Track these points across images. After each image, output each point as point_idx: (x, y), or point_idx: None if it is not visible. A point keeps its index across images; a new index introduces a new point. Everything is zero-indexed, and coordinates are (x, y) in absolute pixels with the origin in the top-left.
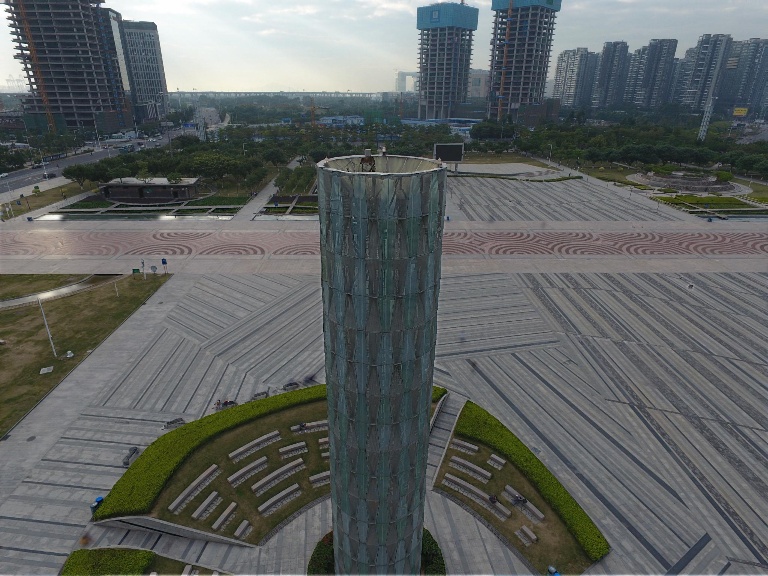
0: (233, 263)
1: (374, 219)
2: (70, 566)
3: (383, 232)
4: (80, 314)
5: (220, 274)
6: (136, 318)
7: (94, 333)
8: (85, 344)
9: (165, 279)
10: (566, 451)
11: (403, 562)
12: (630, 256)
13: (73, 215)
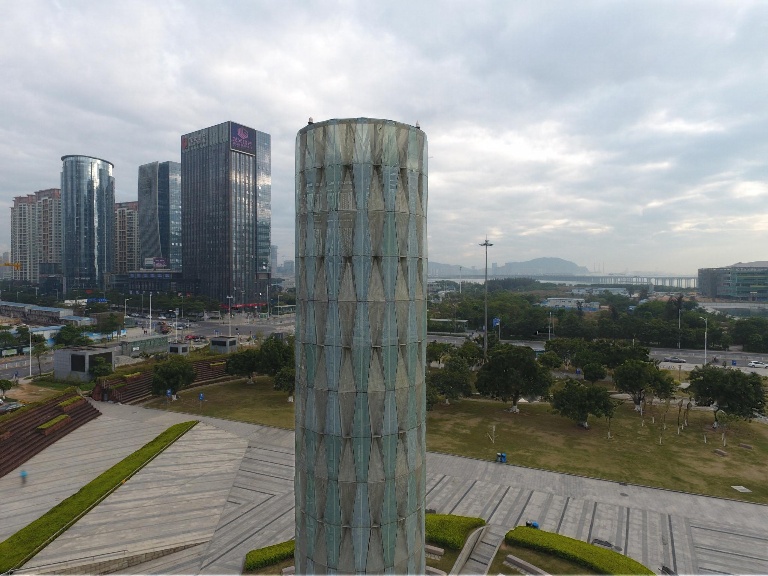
0: None
1: None
2: None
3: None
4: None
5: None
6: None
7: None
8: None
9: None
10: None
11: None
12: None
13: None
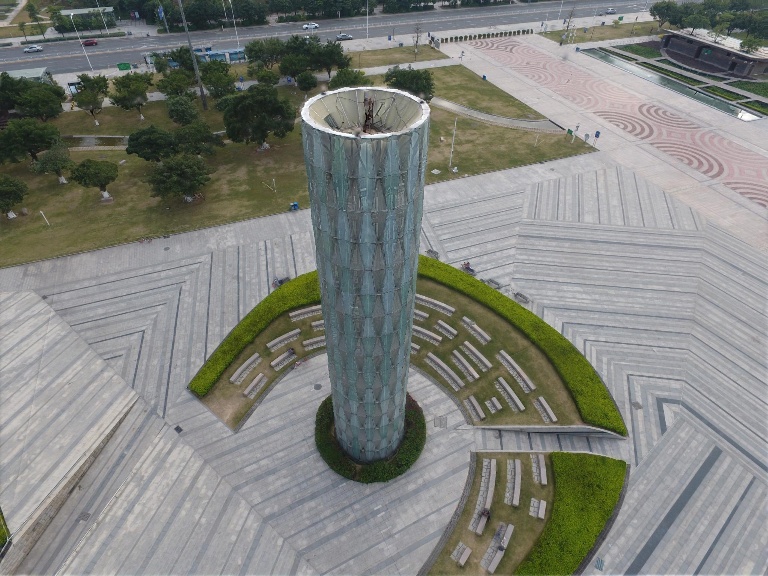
0: (664, 170)
1: None
2: (315, 271)
3: None
4: (498, 146)
5: (635, 173)
6: (521, 170)
7: (485, 165)
8: (471, 169)
9: (585, 151)
10: None
11: (345, 423)
12: None
13: (612, 57)
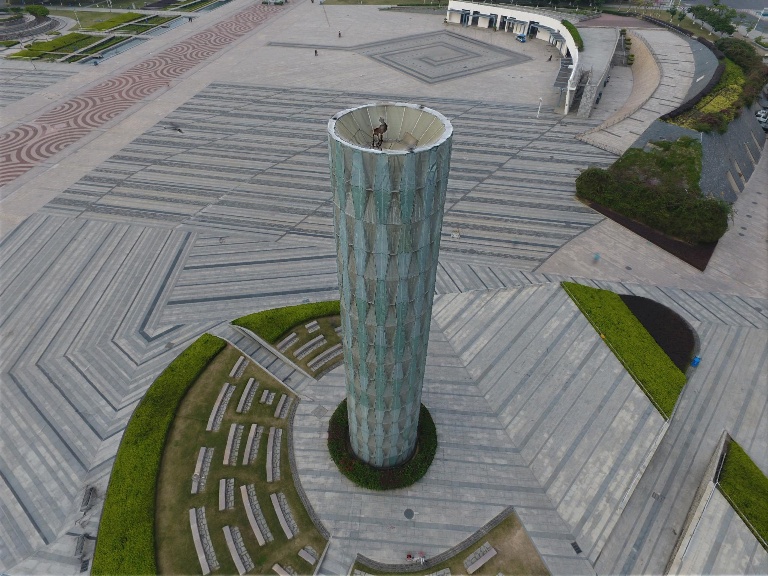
0: None
1: None
2: None
3: None
4: None
5: None
6: None
7: None
8: None
9: None
10: (314, 285)
11: None
12: (101, 129)
13: None
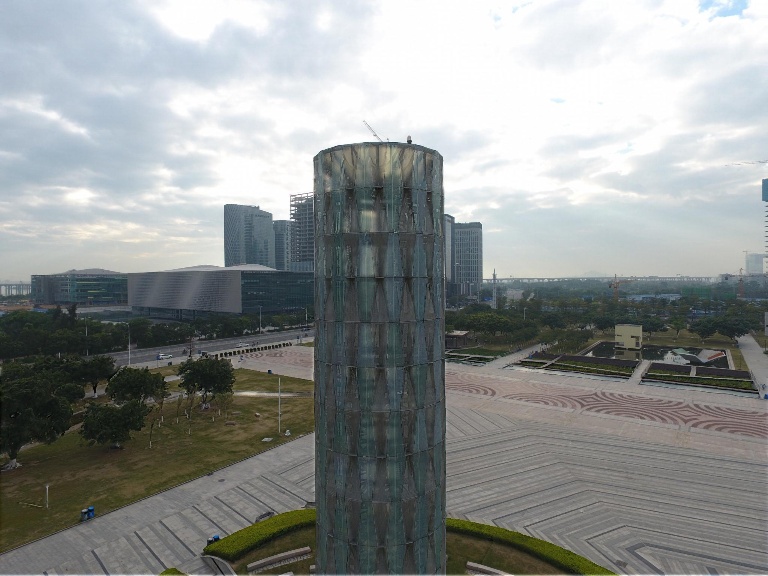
0: (458, 398)
1: (328, 192)
2: (159, 575)
3: (336, 205)
4: None
5: None
6: None
7: None
8: (303, 430)
9: None
10: None
11: None
12: None
13: None
